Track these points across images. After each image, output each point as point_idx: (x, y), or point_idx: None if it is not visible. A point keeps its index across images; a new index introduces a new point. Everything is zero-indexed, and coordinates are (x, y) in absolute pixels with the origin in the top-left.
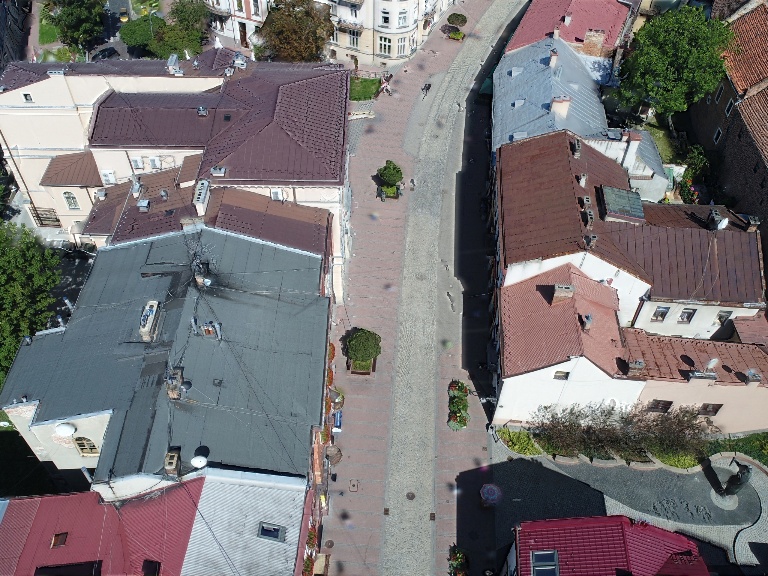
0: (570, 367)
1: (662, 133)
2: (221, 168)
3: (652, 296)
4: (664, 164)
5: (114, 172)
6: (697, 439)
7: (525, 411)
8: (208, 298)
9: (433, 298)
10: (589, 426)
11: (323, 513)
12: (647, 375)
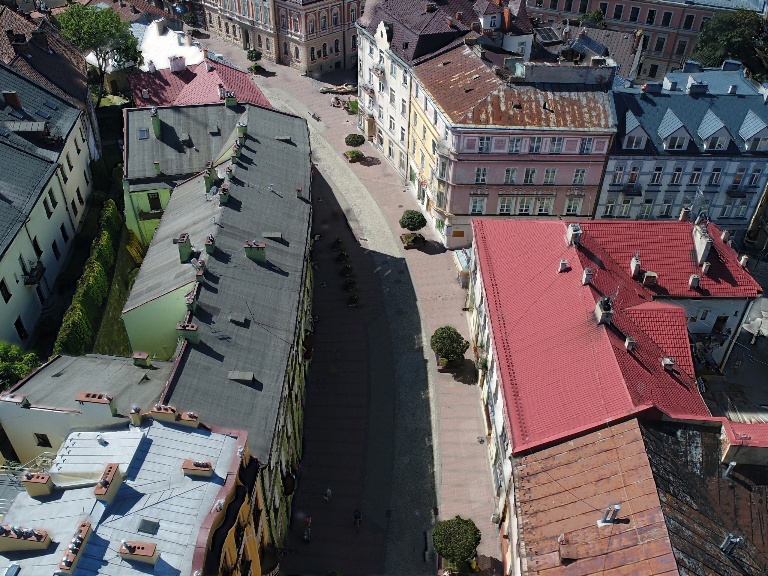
0: None
1: None
2: None
3: None
4: None
5: None
6: None
7: None
8: None
9: None
10: None
11: None
12: (65, 7)
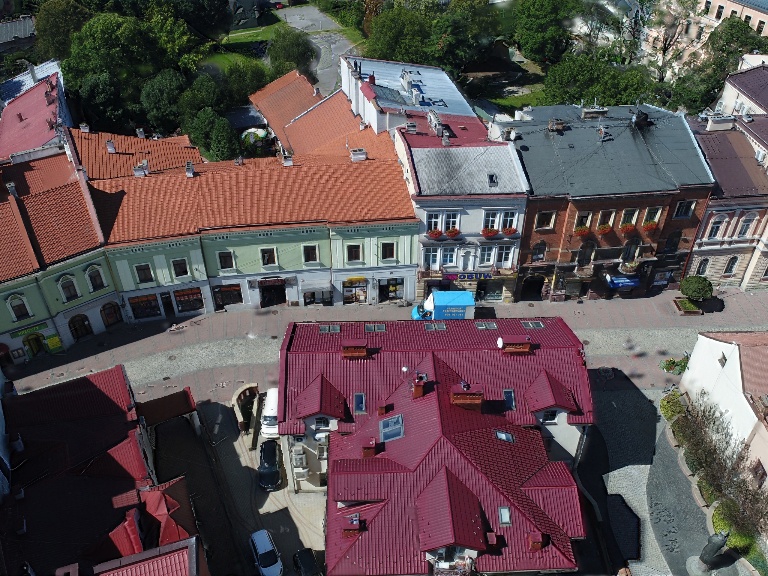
0: (729, 353)
1: None
2: None
3: None
4: None
5: (726, 106)
6: (762, 550)
7: None
8: (628, 130)
9: None
10: None
11: None
12: None
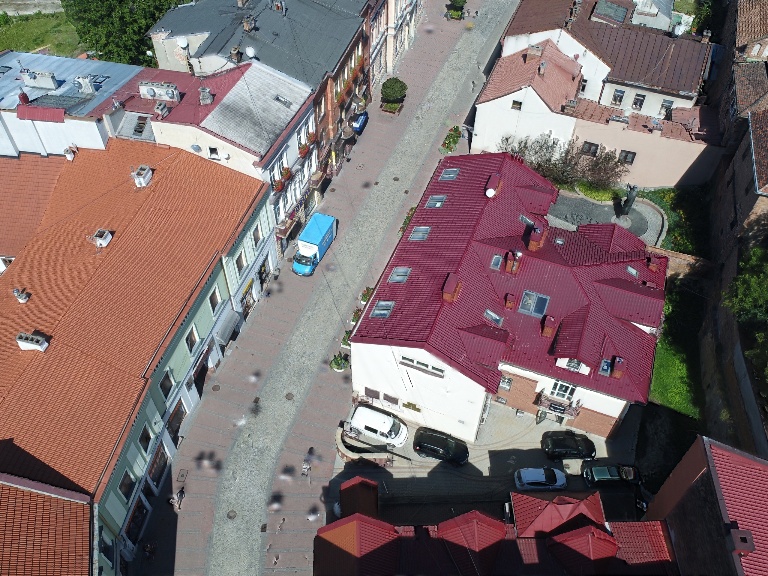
0: (522, 97)
1: (694, 0)
2: None
3: (610, 76)
4: (675, 11)
5: None
6: (619, 187)
7: (493, 142)
8: None
9: (460, 82)
10: (539, 164)
11: (334, 173)
12: (580, 116)
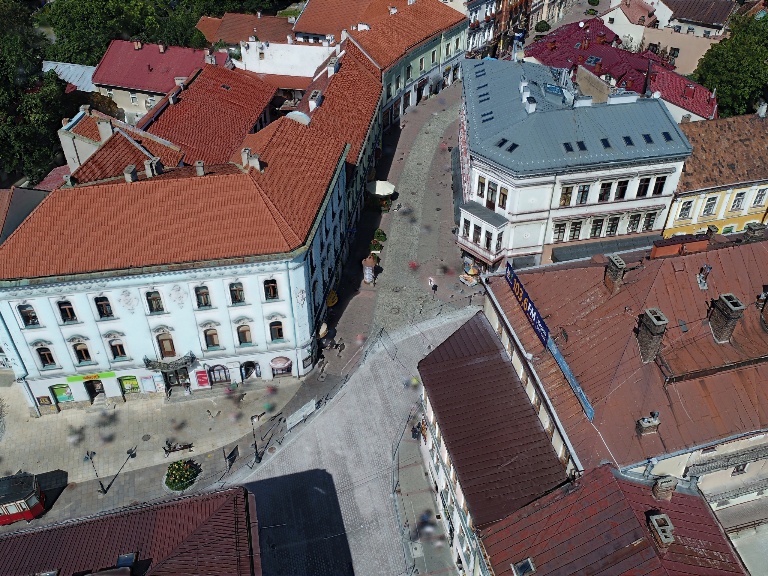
0: (615, 15)
1: None
2: None
3: (672, 16)
4: None
5: None
6: None
7: None
8: None
9: None
10: None
11: (500, 55)
12: None
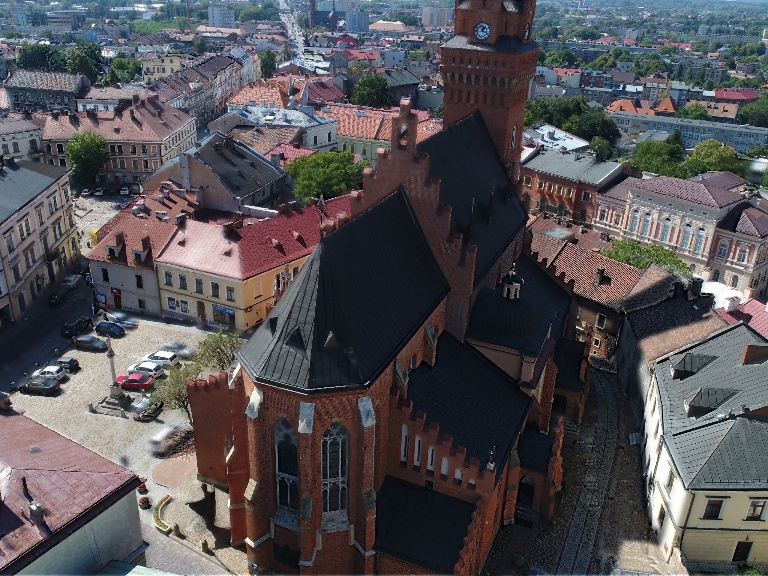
0: None
1: None
2: (658, 174)
3: None
4: None
5: None
6: None
7: None
8: None
9: None
10: None
11: None
12: None
